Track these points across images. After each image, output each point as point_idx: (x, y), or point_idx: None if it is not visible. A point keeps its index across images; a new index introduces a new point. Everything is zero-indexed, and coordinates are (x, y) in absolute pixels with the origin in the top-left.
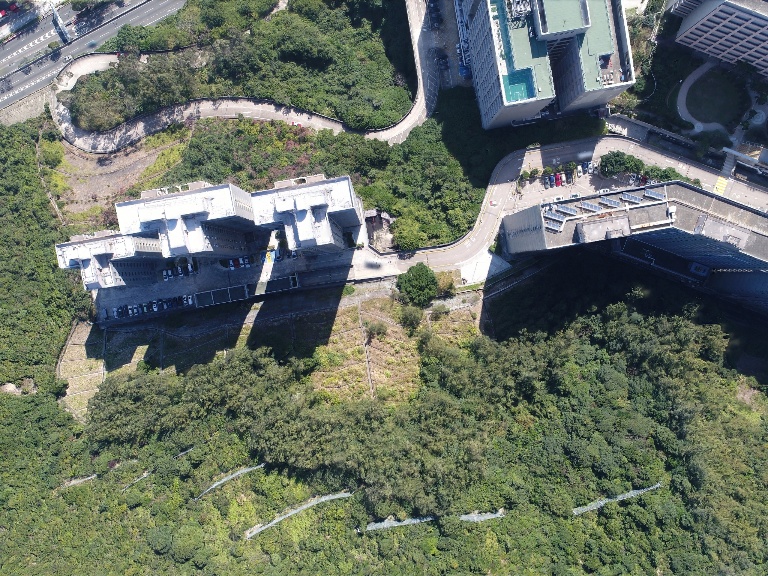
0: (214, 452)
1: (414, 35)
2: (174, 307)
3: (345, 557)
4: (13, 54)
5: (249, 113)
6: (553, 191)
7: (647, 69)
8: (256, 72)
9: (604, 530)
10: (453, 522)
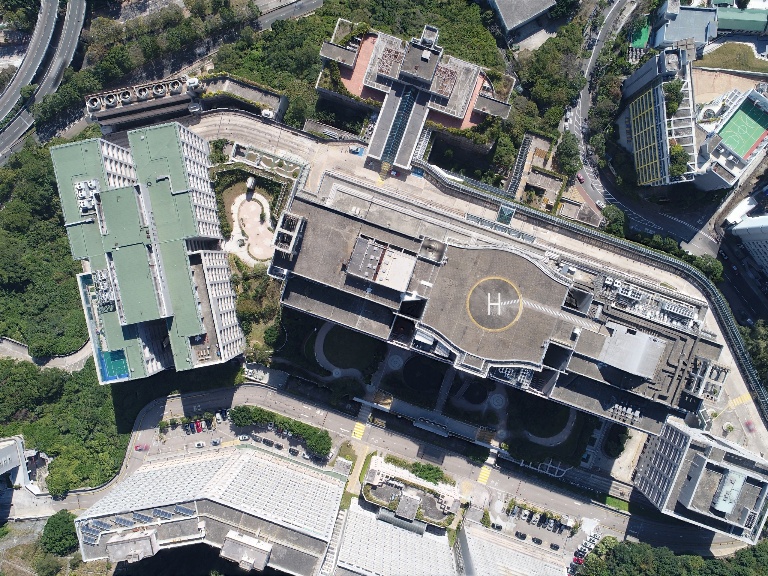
0: None
1: (87, 268)
2: None
3: None
4: None
5: None
6: (195, 437)
7: (277, 321)
8: None
9: None
10: None
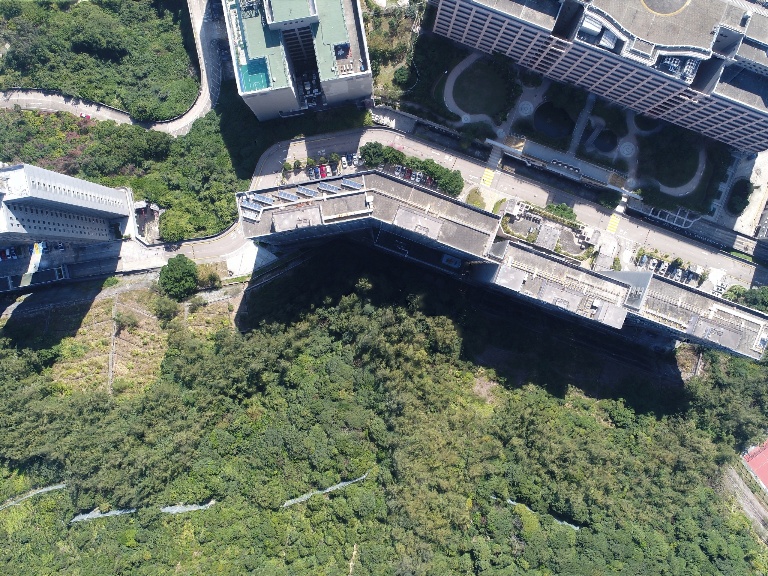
0: None
1: (196, 26)
2: None
3: (50, 549)
4: None
5: (39, 104)
6: None
7: (409, 60)
8: (45, 63)
9: (310, 522)
10: (148, 514)
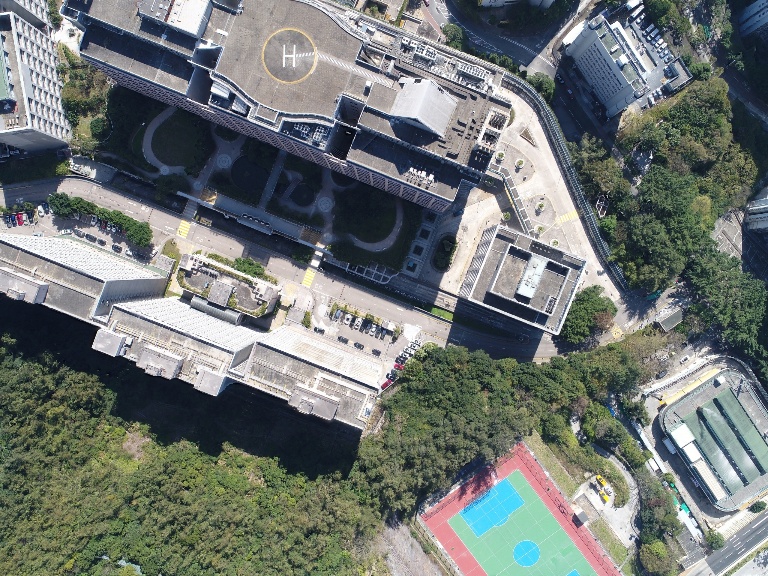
0: None
1: None
2: None
3: None
4: None
5: None
6: (16, 230)
7: (103, 112)
8: None
9: None
10: None
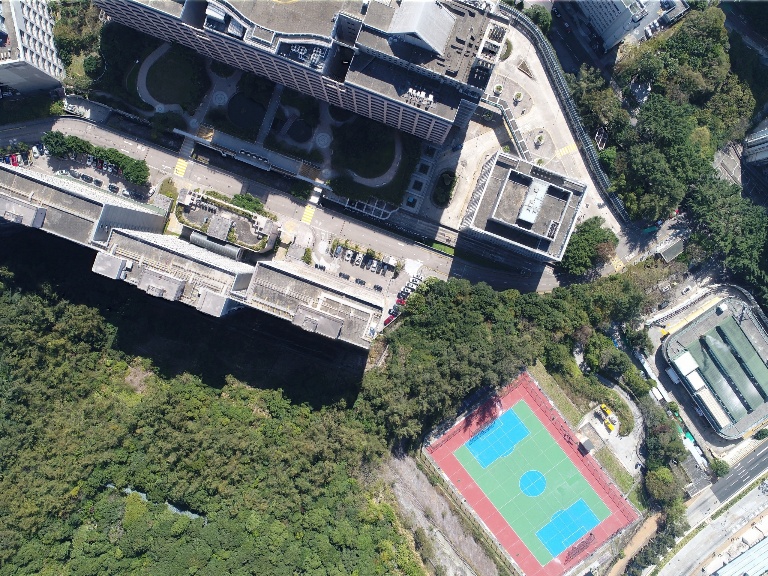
0: None
1: None
2: None
3: None
4: None
5: None
6: None
7: (96, 49)
8: None
9: None
10: None
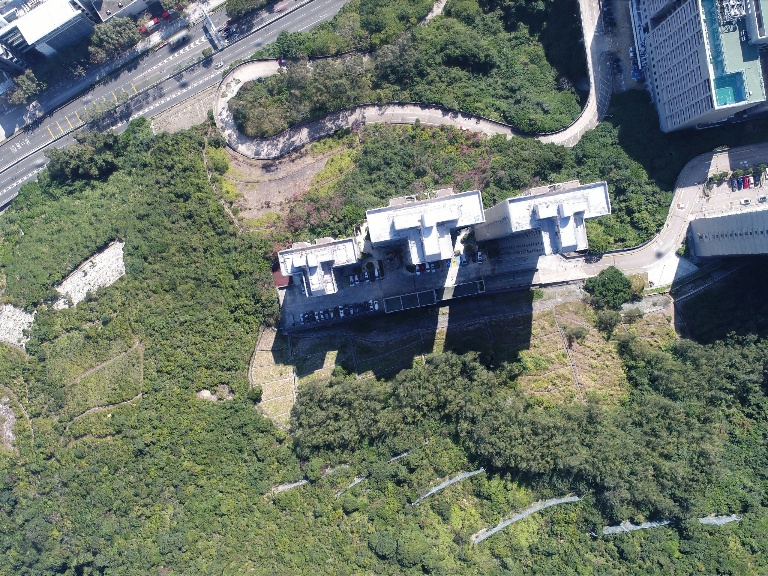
0: (431, 457)
1: (587, 39)
2: (360, 312)
3: (582, 561)
4: (164, 61)
5: None
6: (740, 194)
7: None
8: (423, 77)
9: None
10: (697, 525)
